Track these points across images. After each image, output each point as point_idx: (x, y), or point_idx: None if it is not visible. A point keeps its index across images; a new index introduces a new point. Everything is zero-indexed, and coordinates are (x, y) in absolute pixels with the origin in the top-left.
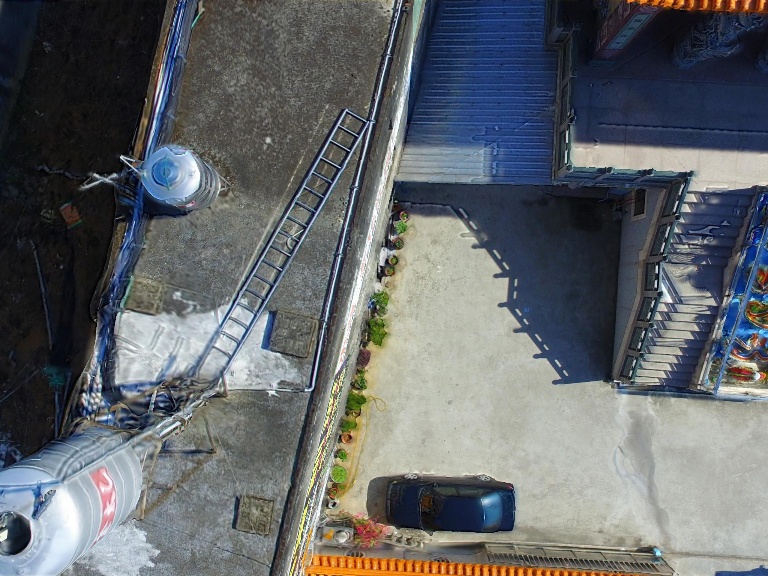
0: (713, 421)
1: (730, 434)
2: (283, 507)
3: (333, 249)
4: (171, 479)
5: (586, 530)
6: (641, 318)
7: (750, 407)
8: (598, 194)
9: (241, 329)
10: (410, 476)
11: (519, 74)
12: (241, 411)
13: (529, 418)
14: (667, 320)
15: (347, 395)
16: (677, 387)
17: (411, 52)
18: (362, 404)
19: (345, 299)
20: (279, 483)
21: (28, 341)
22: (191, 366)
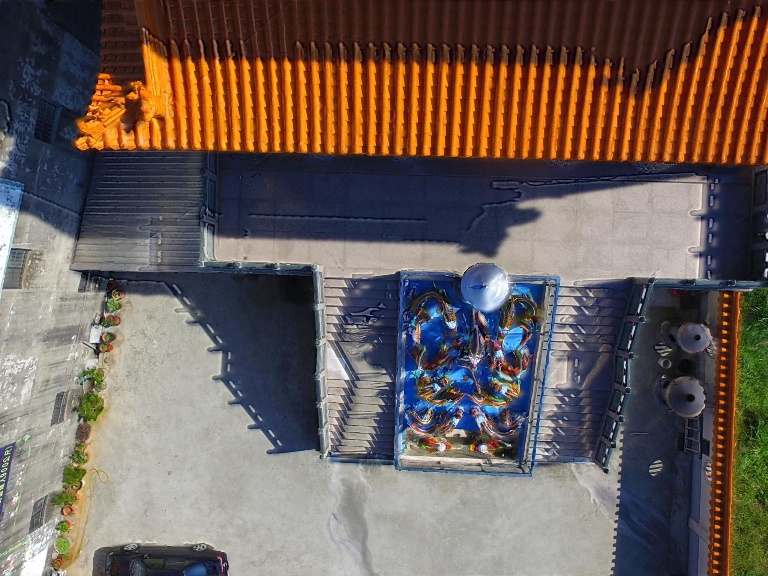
0: (422, 487)
1: (439, 499)
2: None
3: None
4: None
5: None
6: None
7: (457, 473)
8: None
9: None
10: (131, 546)
11: (180, 166)
12: None
13: (246, 487)
14: (353, 395)
15: (63, 470)
16: (386, 455)
17: None
18: (85, 476)
19: None
20: None
21: None
22: None
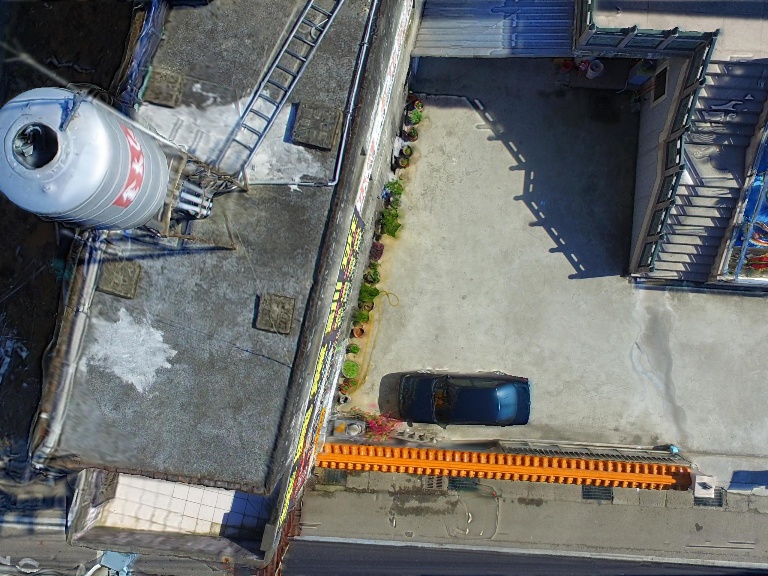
0: (732, 317)
1: (749, 330)
2: (305, 305)
3: (358, 39)
4: (189, 277)
5: (602, 428)
6: (661, 200)
7: None
8: (616, 84)
9: (263, 122)
10: (423, 371)
11: None
12: (262, 207)
13: (544, 313)
14: (687, 205)
15: (360, 286)
16: (695, 282)
17: None
18: (375, 299)
19: (369, 102)
20: (301, 281)
21: (35, 236)
22: (211, 160)
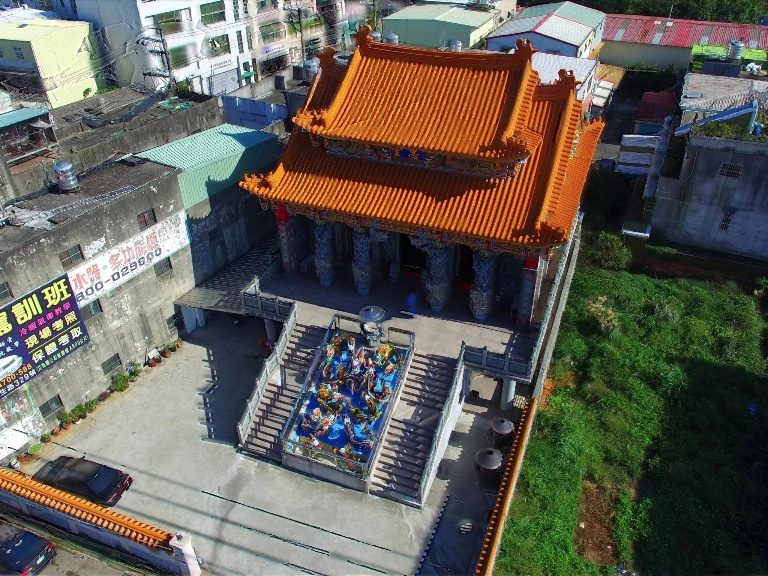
0: (290, 489)
1: (297, 500)
2: None
3: None
4: None
5: None
6: None
7: (319, 487)
8: None
9: None
10: None
11: None
12: None
13: (174, 454)
14: (278, 401)
15: (78, 404)
16: (277, 462)
17: (183, 212)
18: (83, 420)
19: None
20: None
21: None
22: None
